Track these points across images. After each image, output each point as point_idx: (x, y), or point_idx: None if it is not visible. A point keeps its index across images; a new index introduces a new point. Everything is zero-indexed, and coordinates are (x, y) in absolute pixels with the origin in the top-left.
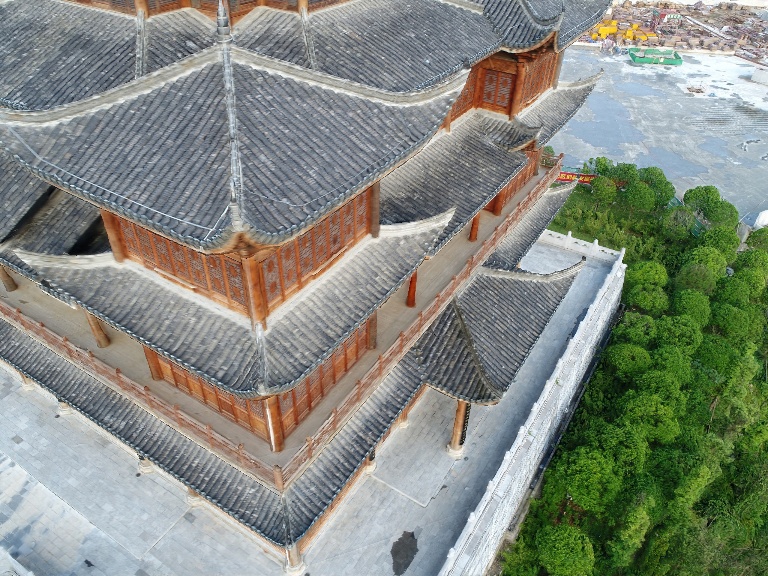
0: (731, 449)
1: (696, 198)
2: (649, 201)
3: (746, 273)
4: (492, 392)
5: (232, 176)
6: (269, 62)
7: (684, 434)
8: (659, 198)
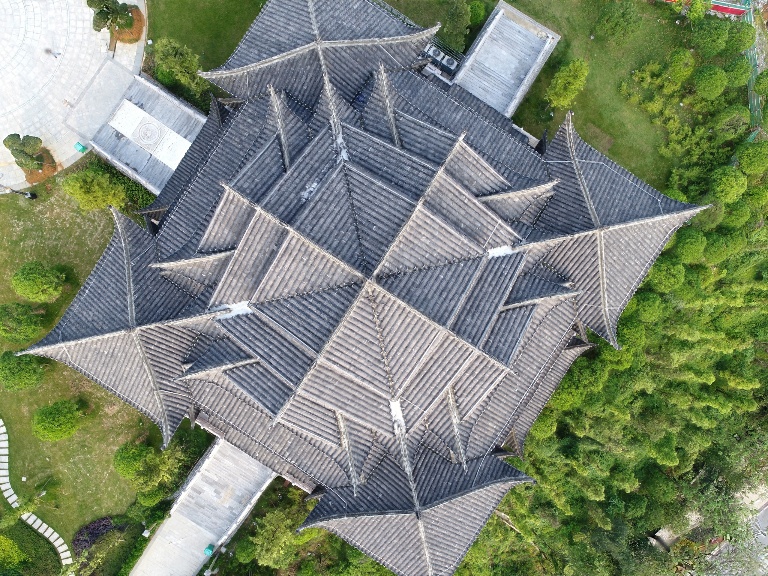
0: (653, 388)
1: (767, 87)
2: (718, 92)
3: (760, 192)
4: (518, 450)
5: None
6: (437, 506)
7: (634, 359)
8: (731, 82)
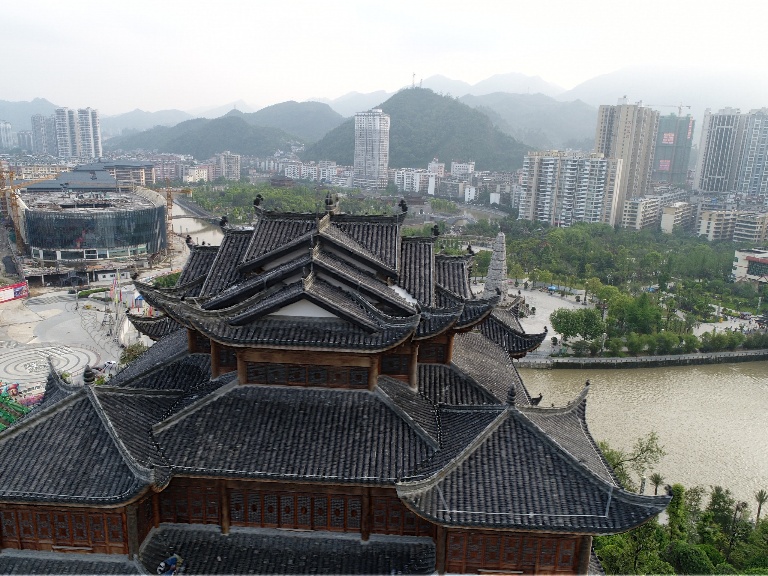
0: None
1: None
2: None
3: None
4: None
5: (503, 306)
6: None
7: None
8: None
